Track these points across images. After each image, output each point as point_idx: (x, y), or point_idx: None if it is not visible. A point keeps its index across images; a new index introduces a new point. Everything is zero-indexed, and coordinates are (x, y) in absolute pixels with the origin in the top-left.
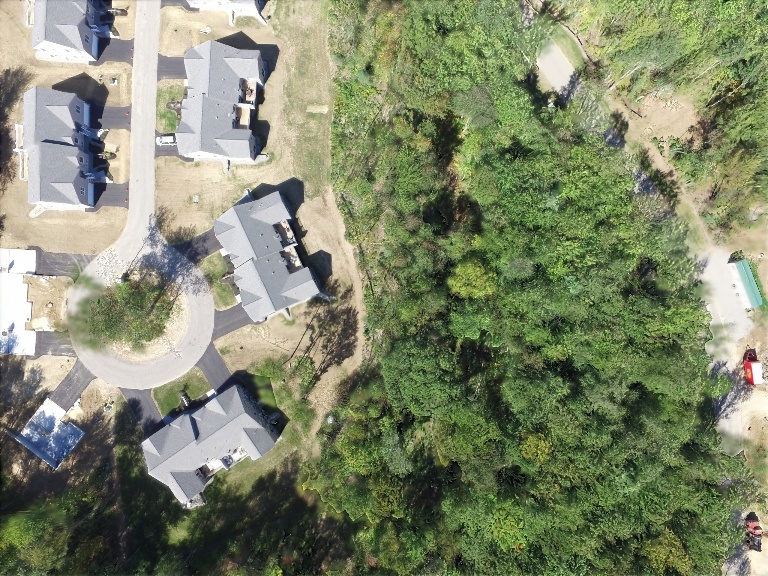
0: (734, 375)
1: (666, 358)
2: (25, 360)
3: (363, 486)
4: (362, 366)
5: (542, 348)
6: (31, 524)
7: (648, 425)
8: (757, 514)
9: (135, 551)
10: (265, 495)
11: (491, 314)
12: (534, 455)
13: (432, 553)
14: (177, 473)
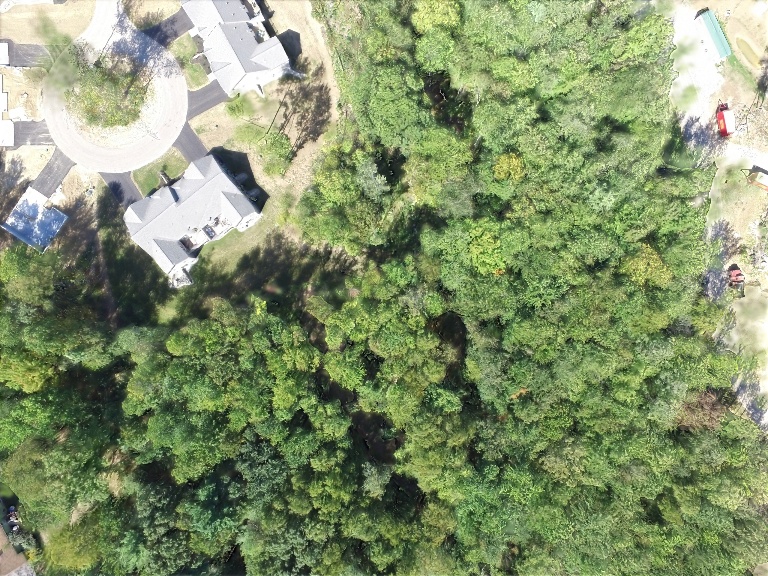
0: (708, 130)
1: (632, 75)
2: (5, 151)
3: (340, 215)
4: (337, 139)
5: (509, 78)
6: (15, 257)
7: (618, 143)
8: (739, 265)
9: (125, 326)
10: (250, 272)
11: (456, 44)
12: (507, 175)
13: (413, 285)
14: (160, 241)
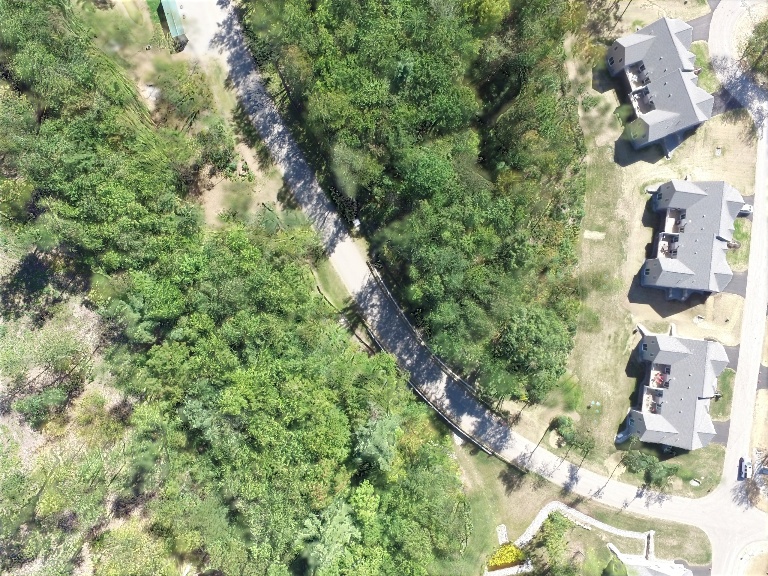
0: None
1: None
2: None
3: None
4: None
5: None
6: None
7: None
8: None
9: None
10: None
11: None
12: None
13: None
14: None
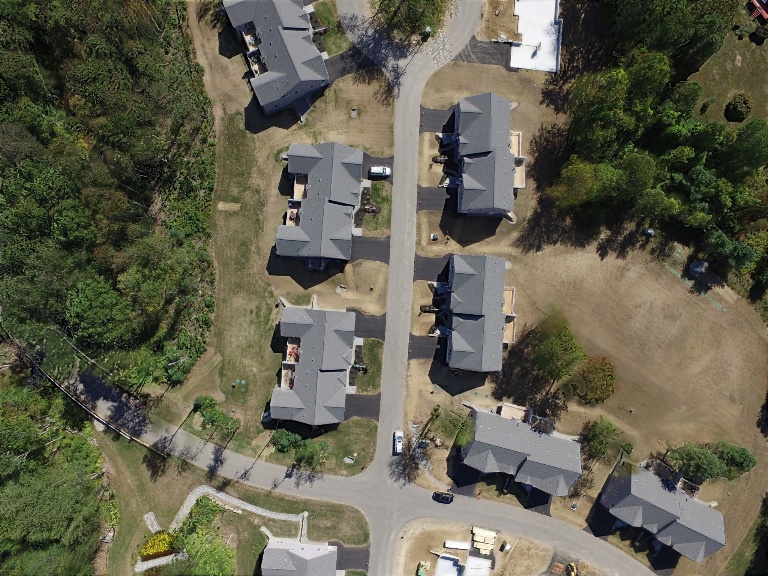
0: None
1: None
2: None
3: None
4: None
5: None
6: None
7: None
8: None
9: None
10: None
11: None
12: None
13: None
14: None
